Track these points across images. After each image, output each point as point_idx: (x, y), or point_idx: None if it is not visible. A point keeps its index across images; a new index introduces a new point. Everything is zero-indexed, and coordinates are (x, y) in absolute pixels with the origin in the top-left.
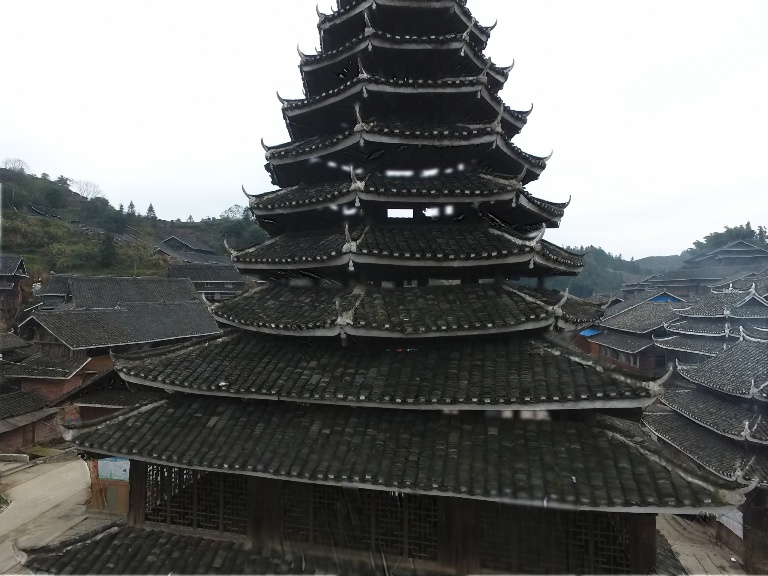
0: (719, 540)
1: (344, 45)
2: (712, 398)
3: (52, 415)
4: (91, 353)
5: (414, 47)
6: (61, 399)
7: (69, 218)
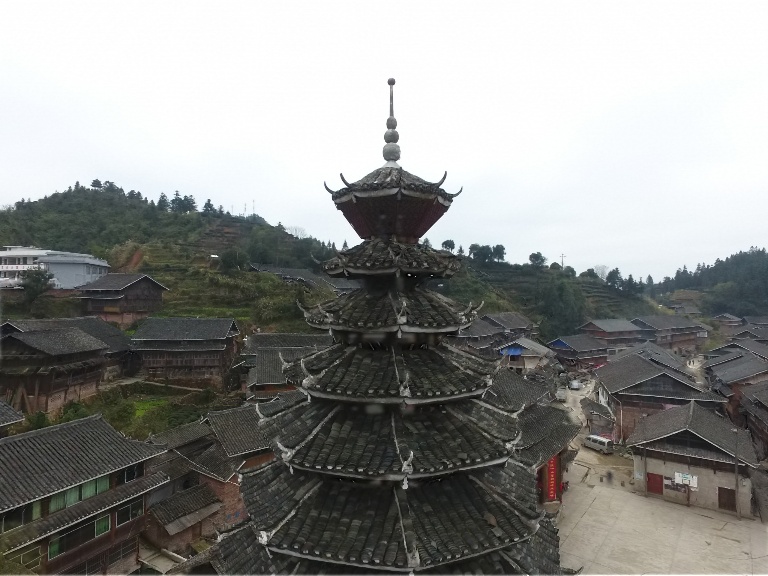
0: None
1: None
2: None
3: (215, 512)
4: (246, 456)
5: (342, 474)
6: (174, 573)
7: (275, 271)
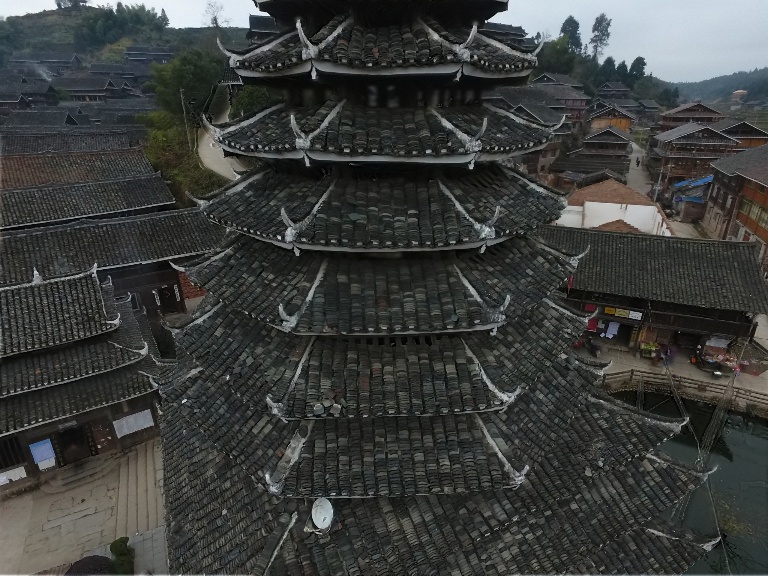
0: (125, 449)
1: (470, 13)
2: (34, 359)
3: None
4: None
5: None
6: None
7: None
